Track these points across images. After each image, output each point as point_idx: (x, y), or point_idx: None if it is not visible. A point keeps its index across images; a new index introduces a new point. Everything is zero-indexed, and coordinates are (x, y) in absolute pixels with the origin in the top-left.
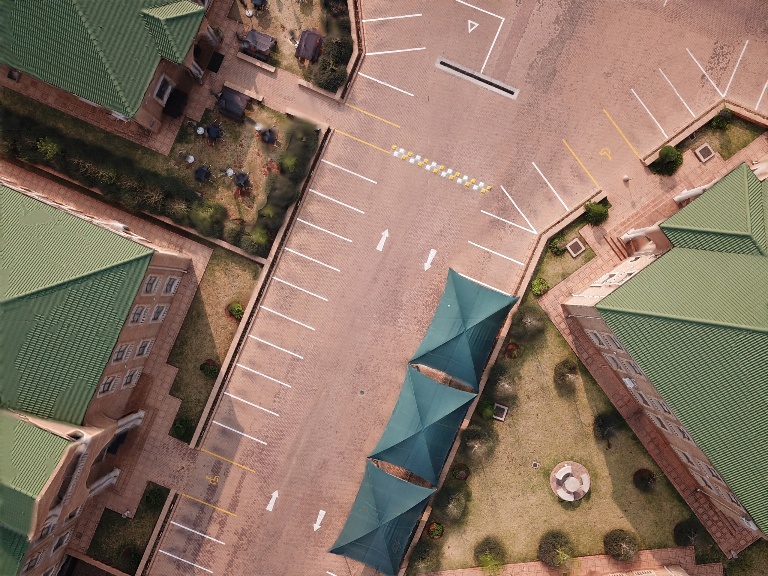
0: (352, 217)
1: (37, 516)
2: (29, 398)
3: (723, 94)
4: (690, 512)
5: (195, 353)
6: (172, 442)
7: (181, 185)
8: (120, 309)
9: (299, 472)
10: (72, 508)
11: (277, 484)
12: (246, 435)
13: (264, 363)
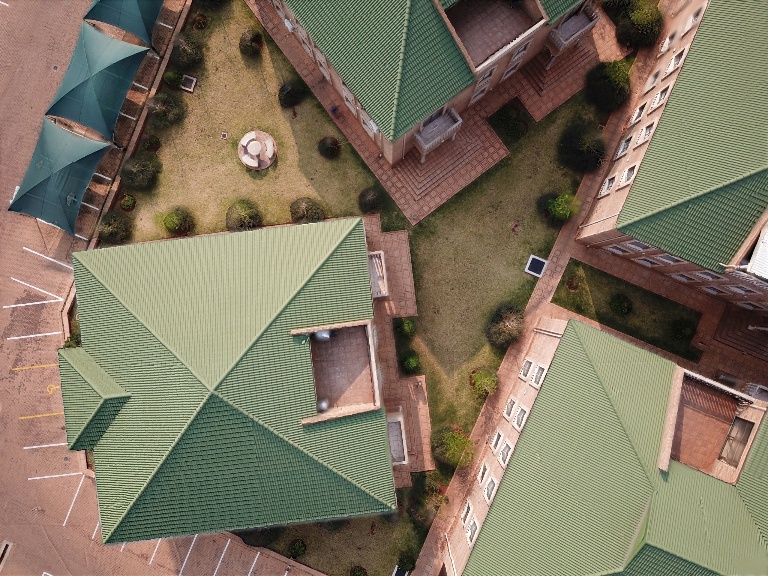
0: None
1: None
2: None
3: None
4: (374, 179)
5: None
6: None
7: None
8: None
9: None
10: None
11: None
12: None
13: None
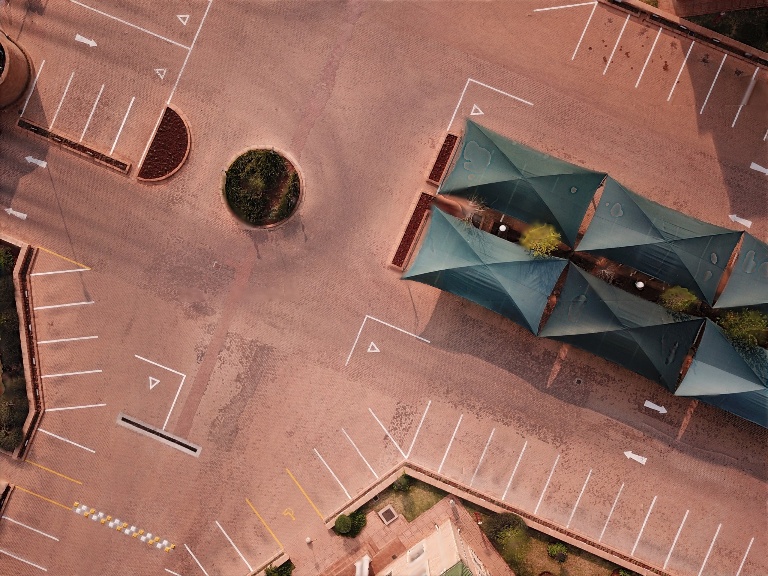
0: (34, 575)
1: None
2: None
3: (406, 455)
4: None
5: None
6: None
7: None
8: None
9: None
10: None
11: None
12: None
13: None
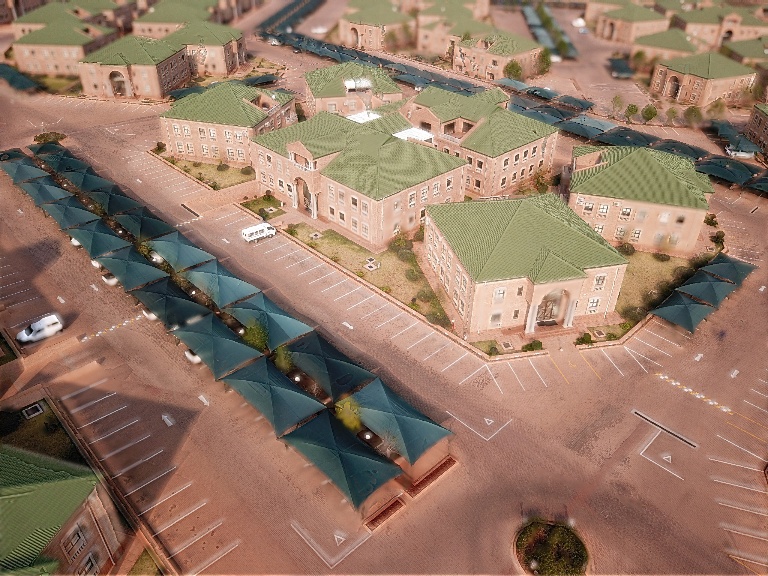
0: (761, 390)
1: None
2: None
3: (486, 366)
4: None
5: None
6: None
7: None
8: None
9: None
10: None
11: None
12: None
13: None
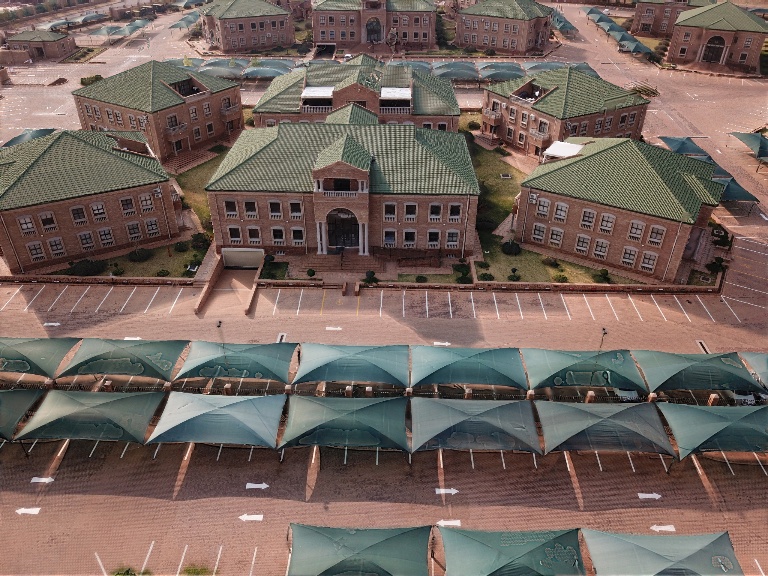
0: None
1: None
2: None
3: None
4: None
5: None
6: None
7: None
8: None
9: None
10: None
11: None
12: None
13: None
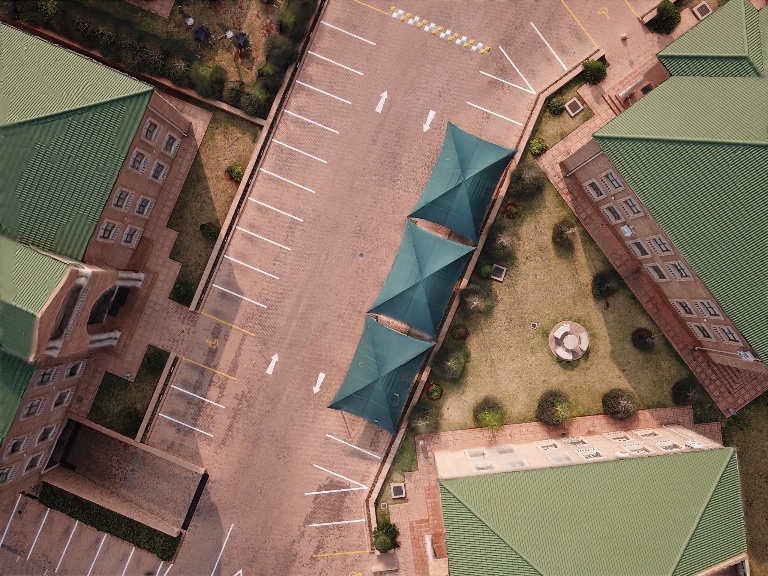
0: (351, 79)
1: (38, 334)
2: (30, 228)
3: None
4: (688, 371)
5: (195, 217)
6: (172, 306)
7: (181, 46)
8: (120, 145)
9: (299, 335)
10: (73, 349)
11: (277, 347)
12: (246, 298)
13: (264, 226)
